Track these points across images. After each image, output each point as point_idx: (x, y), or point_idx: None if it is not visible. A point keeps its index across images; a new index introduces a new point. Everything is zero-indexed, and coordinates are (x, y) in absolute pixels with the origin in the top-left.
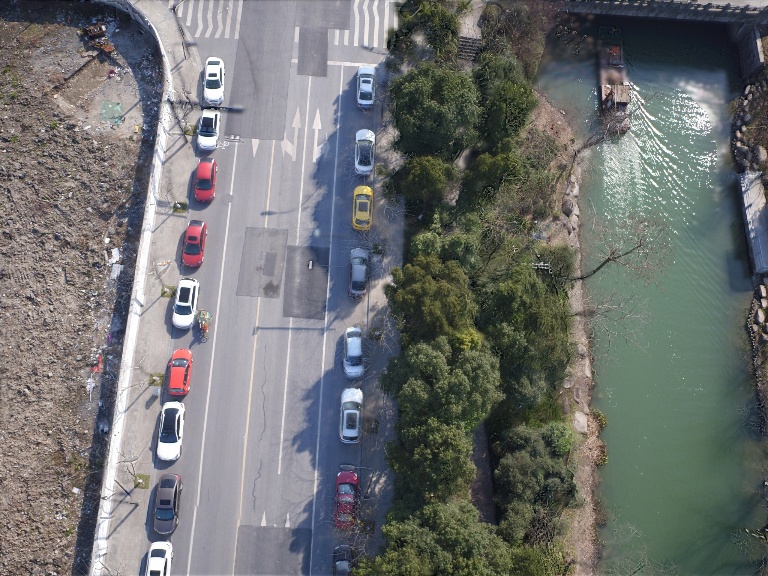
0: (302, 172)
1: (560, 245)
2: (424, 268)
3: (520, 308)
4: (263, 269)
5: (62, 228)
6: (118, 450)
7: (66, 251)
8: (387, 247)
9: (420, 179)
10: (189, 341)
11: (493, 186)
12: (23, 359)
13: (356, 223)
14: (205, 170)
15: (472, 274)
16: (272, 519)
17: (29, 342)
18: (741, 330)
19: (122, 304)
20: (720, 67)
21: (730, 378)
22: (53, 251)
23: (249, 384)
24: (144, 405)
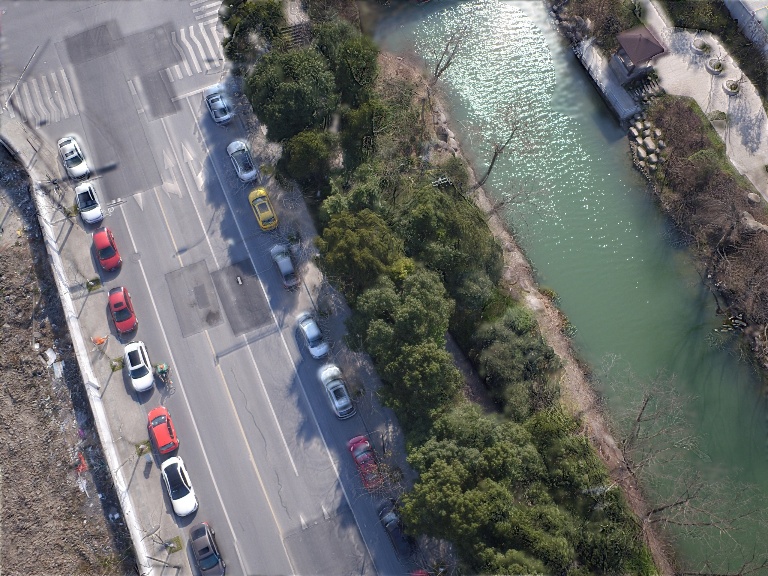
0: (193, 204)
1: (450, 168)
2: (340, 226)
3: (439, 224)
4: (197, 304)
5: None
6: (137, 528)
7: (1, 373)
8: (301, 234)
9: (301, 155)
10: (158, 399)
11: (368, 134)
12: (4, 491)
13: (263, 225)
14: (102, 240)
15: (385, 216)
16: (310, 519)
17: (3, 473)
18: (632, 171)
19: (78, 396)
20: None
21: (642, 214)
22: None
23: (233, 410)
24: (142, 476)
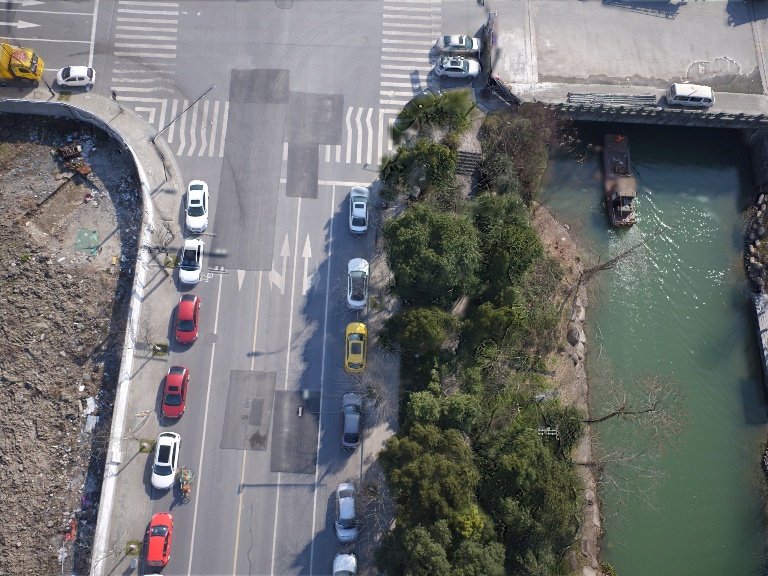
0: (291, 306)
1: (566, 379)
2: (422, 443)
3: (525, 482)
4: (249, 418)
5: (33, 375)
6: None
7: (37, 401)
8: (382, 390)
9: (417, 336)
10: (169, 502)
11: (495, 340)
12: None
13: (349, 366)
14: (187, 310)
15: (473, 441)
16: None
17: None
18: (757, 467)
19: (97, 461)
20: (732, 174)
21: (746, 522)
22: (23, 402)
23: (234, 550)
24: None
